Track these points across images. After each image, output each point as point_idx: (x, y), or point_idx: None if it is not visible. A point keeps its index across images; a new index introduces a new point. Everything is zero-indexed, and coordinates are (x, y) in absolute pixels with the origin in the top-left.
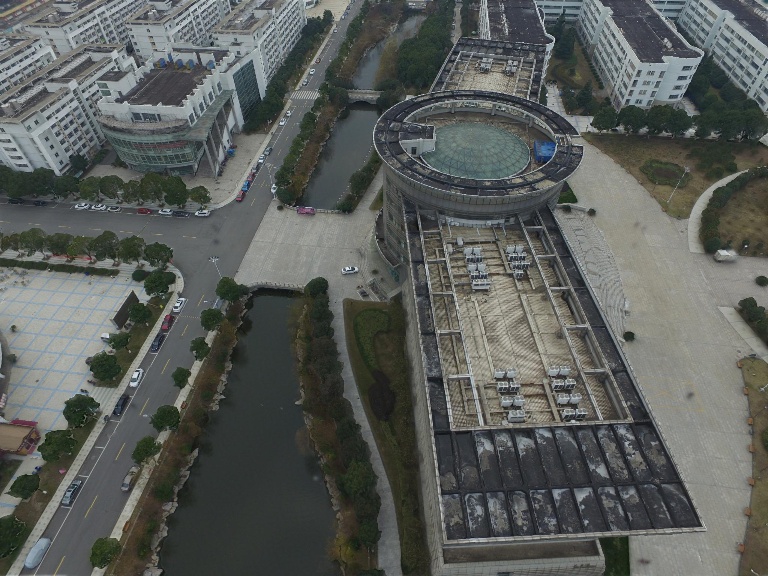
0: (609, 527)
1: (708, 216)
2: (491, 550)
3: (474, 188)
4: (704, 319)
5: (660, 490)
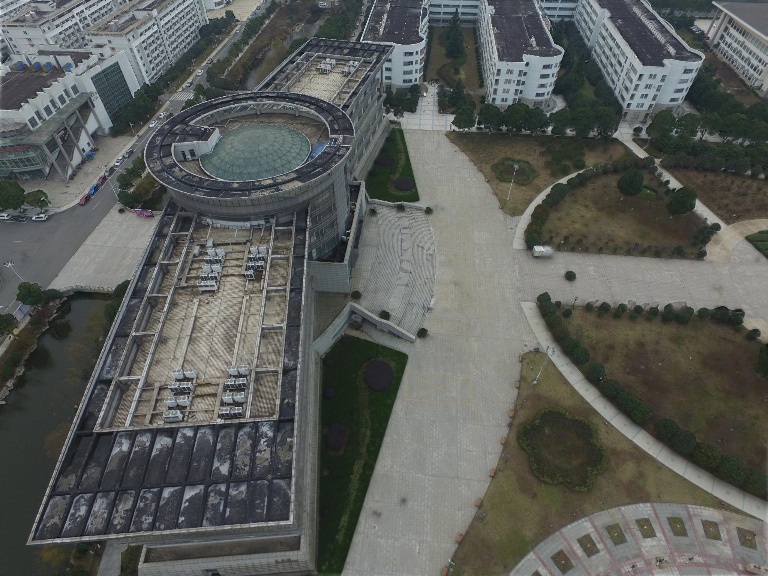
0: (198, 523)
1: (534, 213)
2: (198, 548)
3: (219, 190)
4: (503, 314)
5: (268, 485)
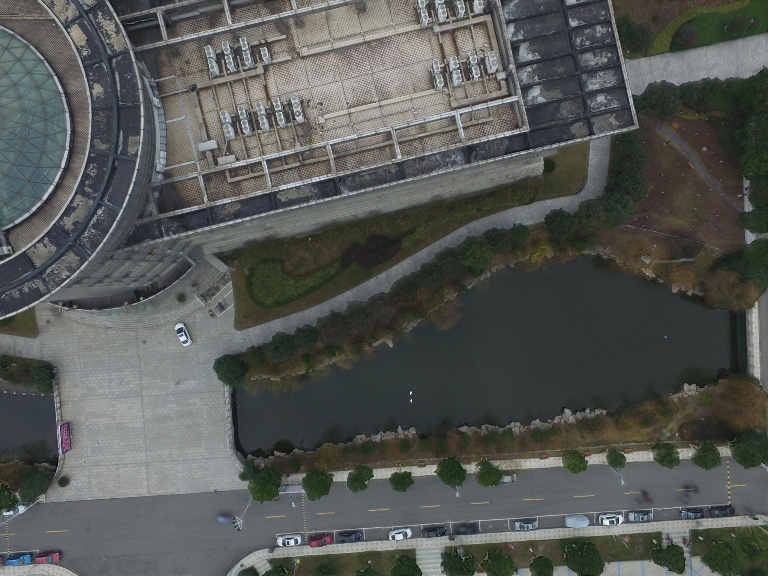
0: None
1: None
2: None
3: (118, 112)
4: None
5: None
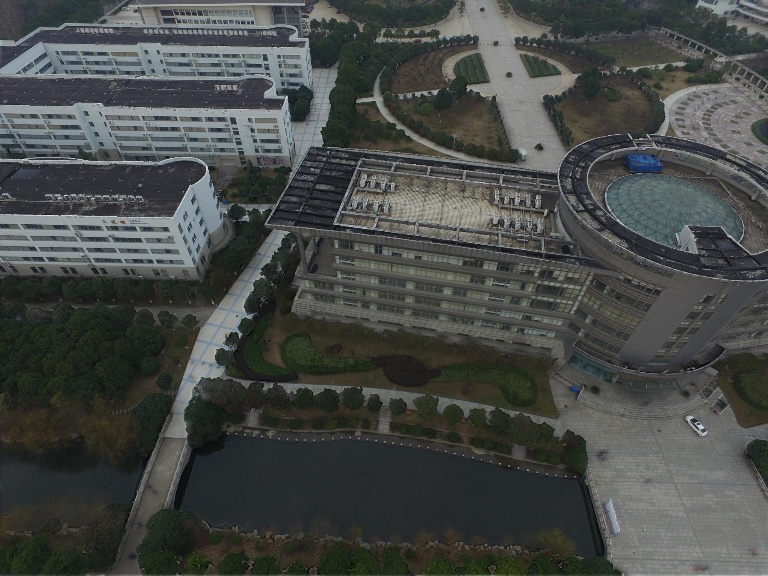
0: None
1: (484, 148)
2: None
3: None
4: None
5: None
